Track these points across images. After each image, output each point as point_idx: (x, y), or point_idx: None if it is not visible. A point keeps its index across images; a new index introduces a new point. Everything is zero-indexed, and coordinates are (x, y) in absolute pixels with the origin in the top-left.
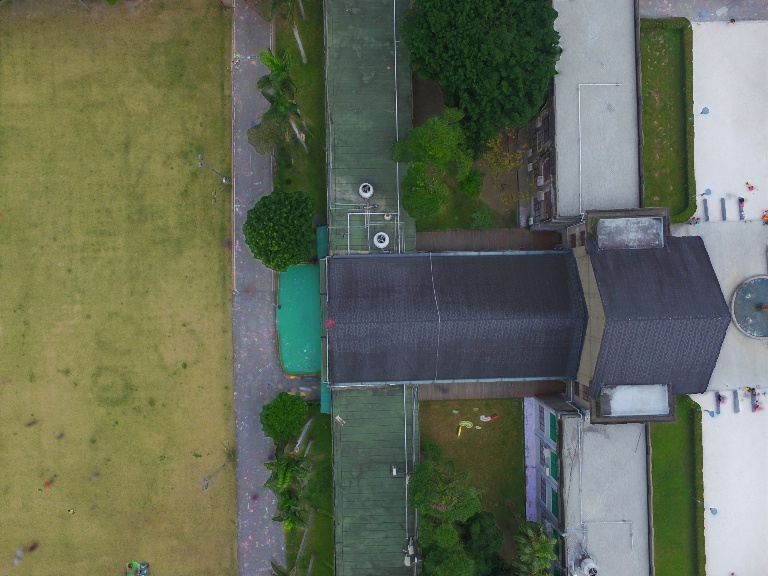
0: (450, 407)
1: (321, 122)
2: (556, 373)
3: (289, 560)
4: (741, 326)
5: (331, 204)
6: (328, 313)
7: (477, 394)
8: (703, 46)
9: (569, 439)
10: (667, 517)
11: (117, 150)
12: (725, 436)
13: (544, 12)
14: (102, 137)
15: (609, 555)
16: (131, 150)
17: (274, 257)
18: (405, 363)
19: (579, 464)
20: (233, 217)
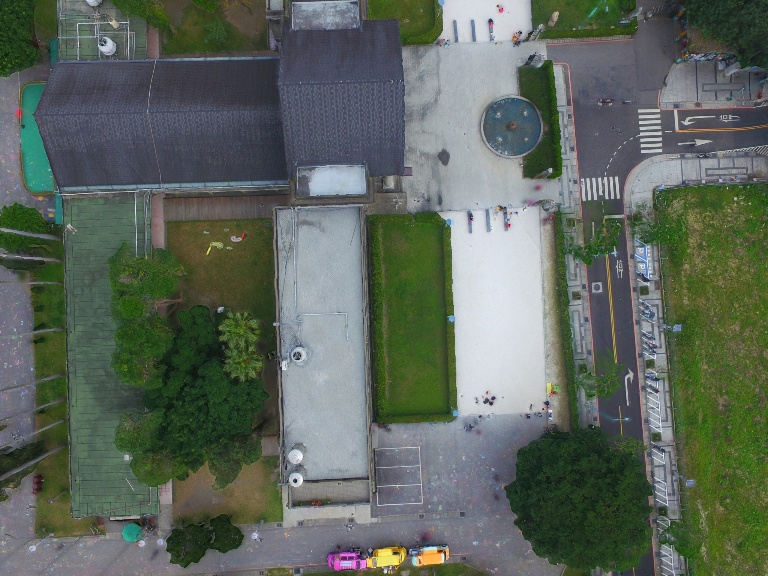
0: (201, 228)
1: None
2: (283, 176)
3: (38, 381)
4: (491, 145)
5: (61, 14)
6: (37, 107)
7: (227, 215)
8: None
9: (284, 232)
10: (420, 336)
11: None
12: (478, 256)
13: None
14: None
15: (325, 347)
16: None
17: None
18: (125, 163)
19: (293, 256)
20: None
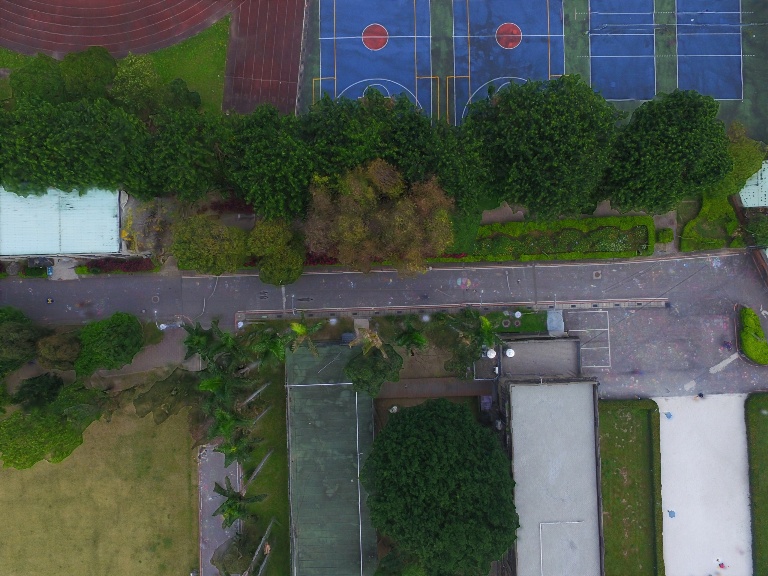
0: None
1: (288, 509)
2: None
3: None
4: None
5: None
6: None
7: None
8: (671, 422)
9: None
10: None
11: (85, 545)
12: None
13: (501, 488)
14: (71, 532)
15: None
16: (99, 545)
17: None
18: None
19: None
20: None
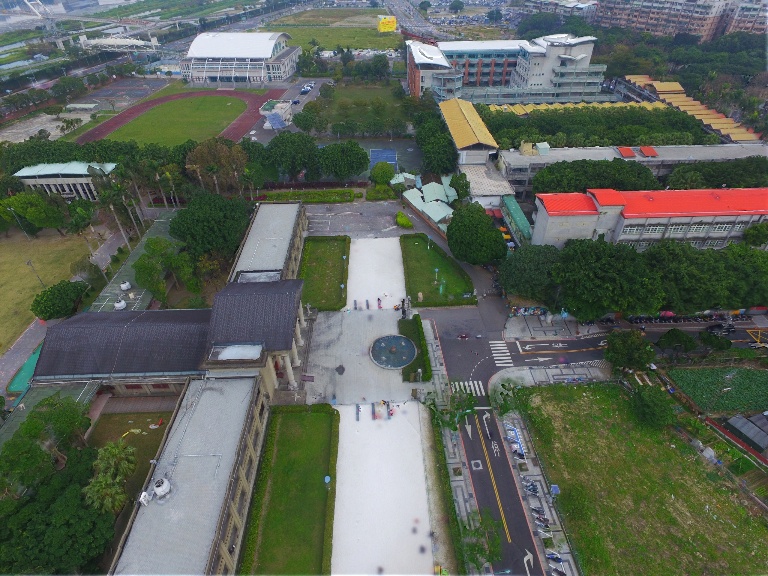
0: (128, 419)
1: None
2: None
3: None
4: (377, 362)
5: (101, 294)
6: None
7: (155, 409)
8: None
9: (190, 395)
10: (300, 512)
11: None
12: (364, 439)
13: None
14: None
15: (191, 485)
16: (3, 287)
17: None
18: (93, 359)
19: (191, 411)
20: None
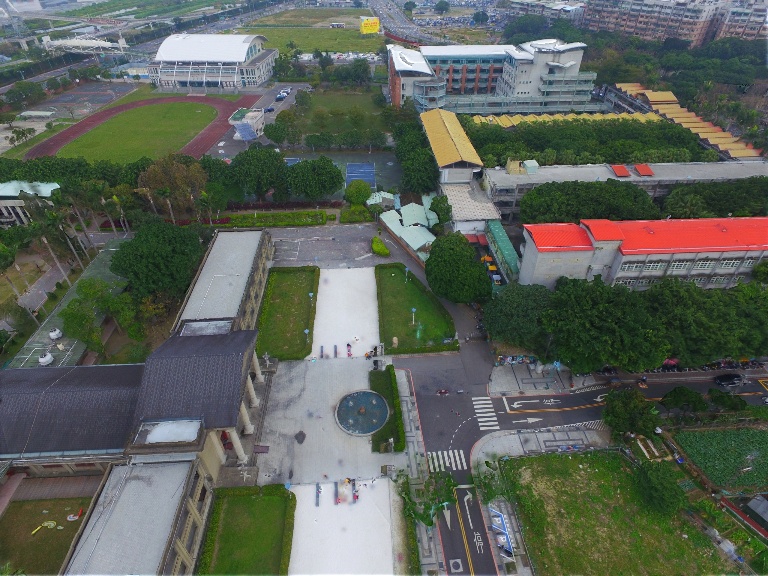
0: (43, 507)
1: None
2: None
3: None
4: (343, 426)
5: (27, 344)
6: None
7: (76, 493)
8: (330, 278)
9: (111, 487)
10: None
11: None
12: (324, 531)
13: None
14: None
15: None
16: None
17: None
18: (1, 435)
19: (109, 511)
20: None
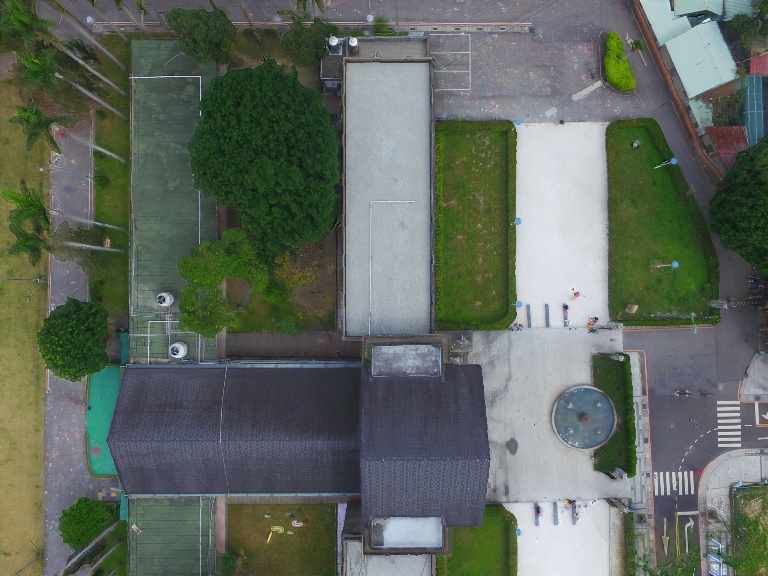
0: (262, 511)
1: None
2: (351, 490)
3: None
4: (562, 436)
5: (132, 311)
6: (110, 430)
7: (289, 499)
8: (530, 148)
9: (353, 562)
10: None
11: None
12: (544, 548)
13: (318, 137)
14: None
15: None
16: None
17: (61, 370)
18: (194, 478)
19: None
20: (48, 316)
